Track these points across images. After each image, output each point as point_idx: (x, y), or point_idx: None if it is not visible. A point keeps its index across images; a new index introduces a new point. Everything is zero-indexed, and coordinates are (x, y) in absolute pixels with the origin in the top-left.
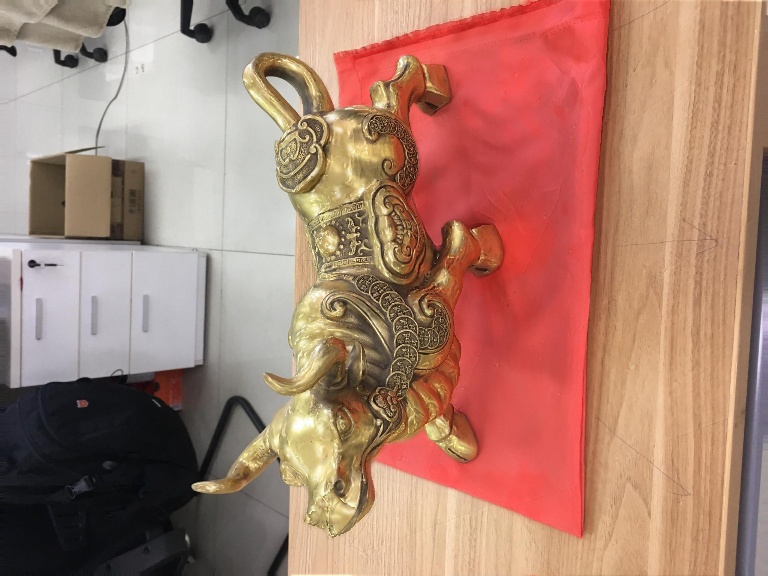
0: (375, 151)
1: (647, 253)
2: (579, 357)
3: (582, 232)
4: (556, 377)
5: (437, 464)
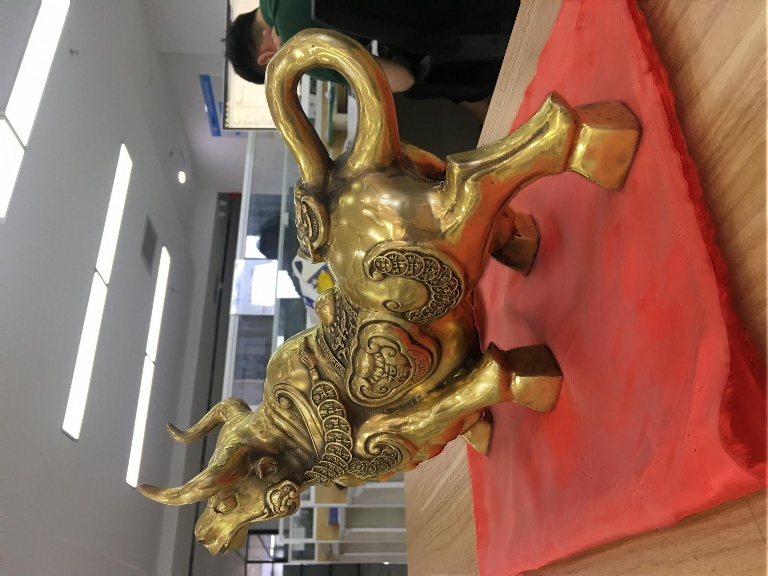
0: (375, 289)
1: None
2: (517, 566)
3: (556, 544)
4: (513, 535)
5: None
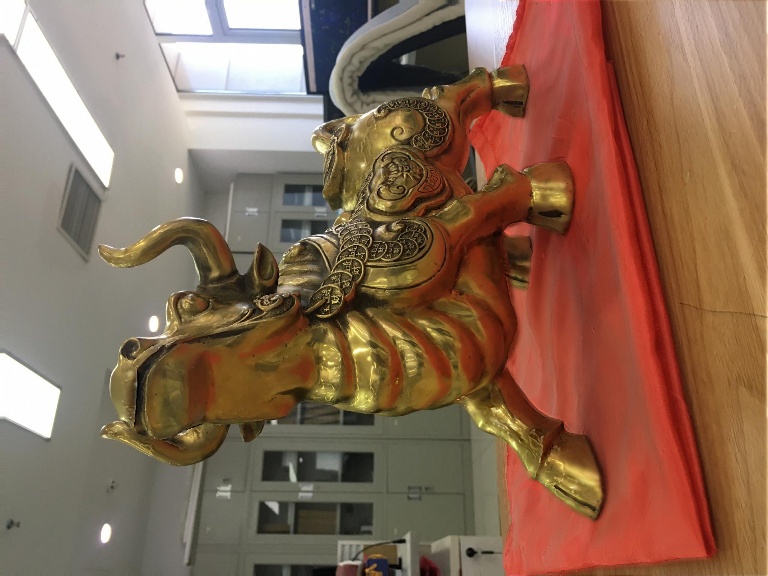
0: (384, 124)
1: (656, 13)
2: (619, 216)
3: (584, 60)
4: None
5: (573, 536)
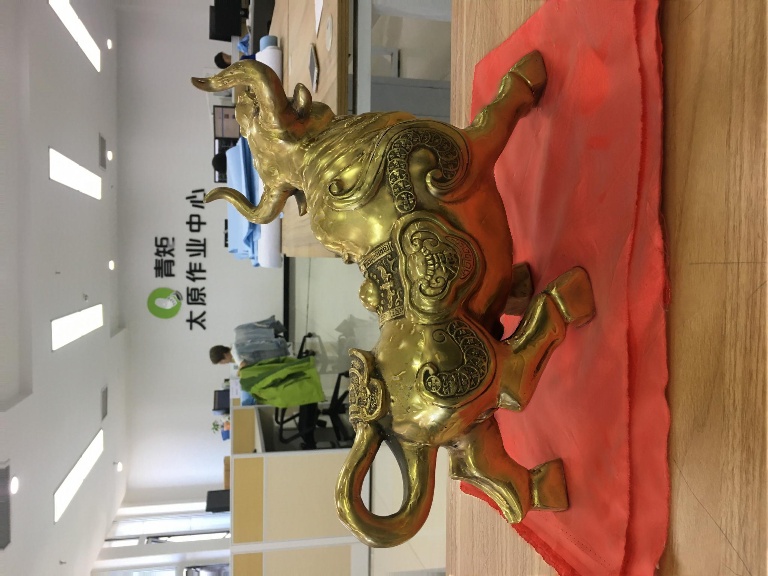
0: None
1: None
2: None
3: None
4: None
5: (540, 33)
